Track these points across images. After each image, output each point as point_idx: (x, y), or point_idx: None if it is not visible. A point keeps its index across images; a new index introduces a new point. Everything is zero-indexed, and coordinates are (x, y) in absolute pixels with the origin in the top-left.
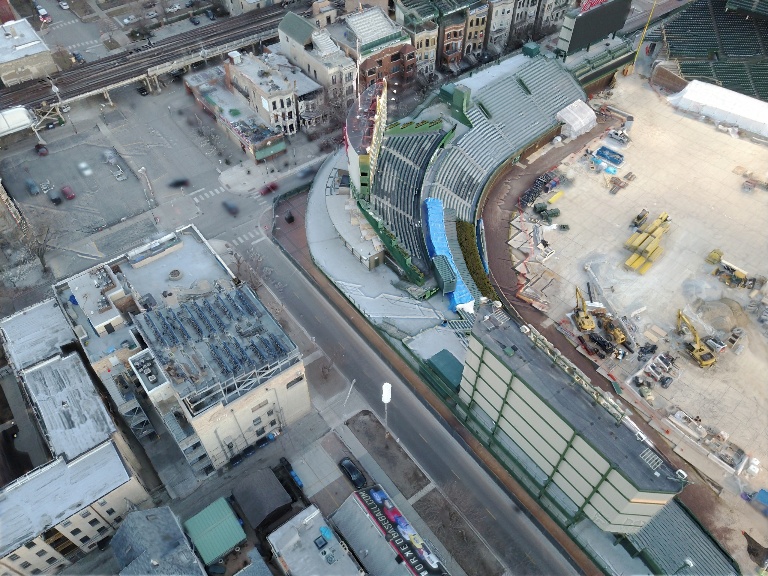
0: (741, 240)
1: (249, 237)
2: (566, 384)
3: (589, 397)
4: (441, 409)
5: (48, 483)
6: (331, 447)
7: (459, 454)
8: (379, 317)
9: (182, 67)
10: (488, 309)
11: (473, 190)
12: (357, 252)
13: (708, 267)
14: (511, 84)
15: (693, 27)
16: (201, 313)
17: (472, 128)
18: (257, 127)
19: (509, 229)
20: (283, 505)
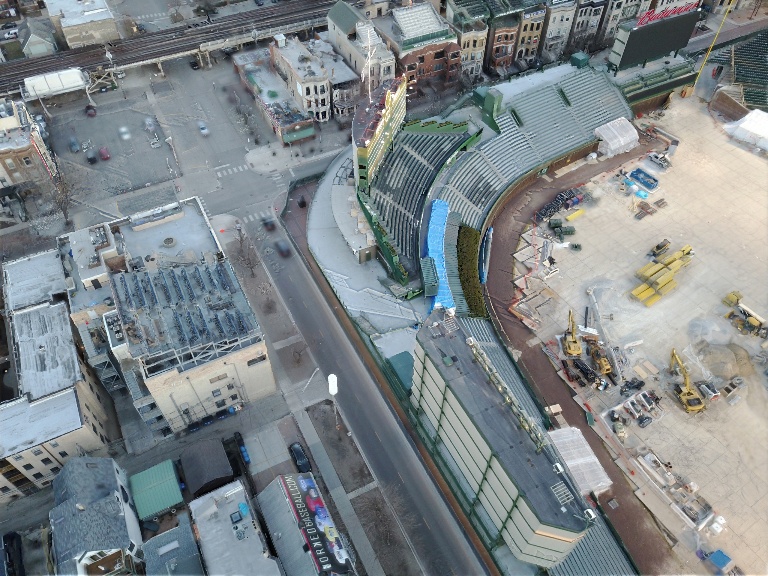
0: (767, 285)
1: (260, 216)
2: (497, 403)
3: (516, 420)
4: (402, 411)
5: (9, 418)
6: (286, 430)
7: (409, 458)
8: (357, 310)
9: (235, 45)
10: (440, 316)
11: (488, 197)
12: (349, 243)
13: (723, 309)
14: (551, 94)
15: (767, 53)
16: (175, 281)
17: (500, 134)
18: (290, 111)
19: (518, 241)
20: (223, 477)
